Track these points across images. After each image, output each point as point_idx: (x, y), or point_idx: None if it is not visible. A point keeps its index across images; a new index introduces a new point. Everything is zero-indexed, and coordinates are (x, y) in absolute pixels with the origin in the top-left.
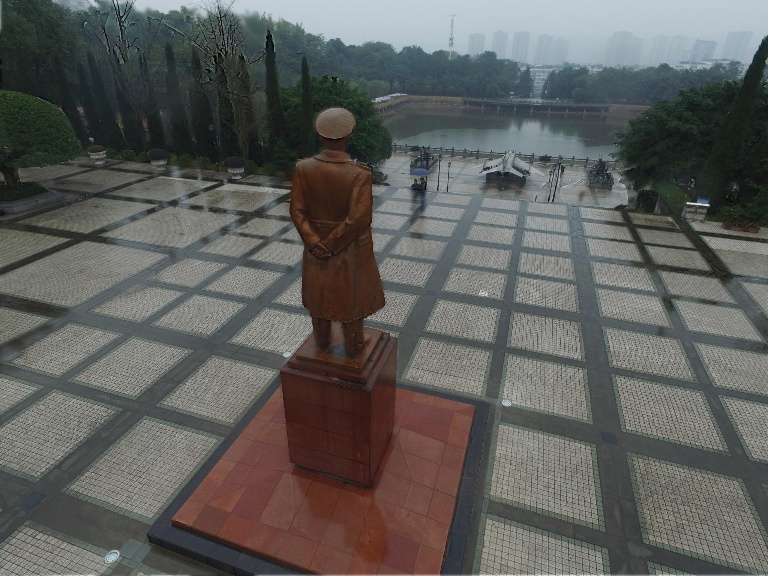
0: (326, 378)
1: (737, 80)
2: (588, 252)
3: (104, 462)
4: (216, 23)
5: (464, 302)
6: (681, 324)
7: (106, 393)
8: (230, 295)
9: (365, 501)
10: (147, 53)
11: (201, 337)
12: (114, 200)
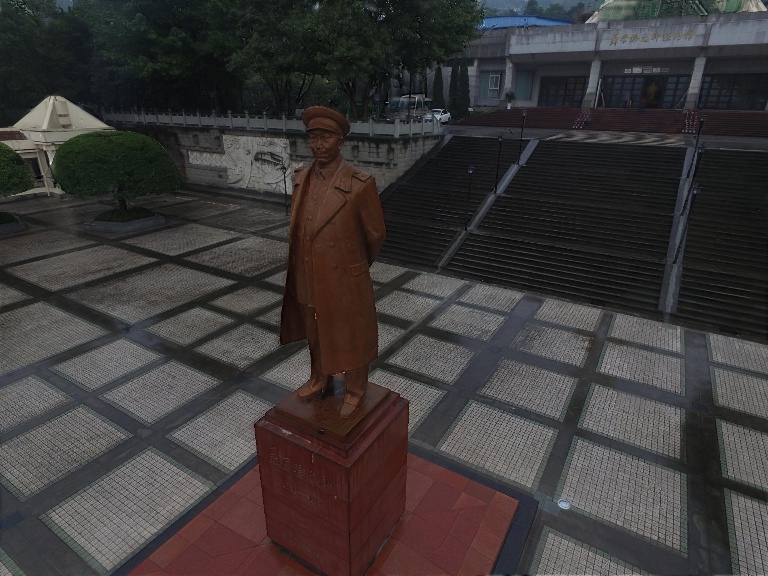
0: None
1: None
2: None
3: None
4: None
5: None
6: None
7: None
8: None
9: None
10: None
11: None
12: None
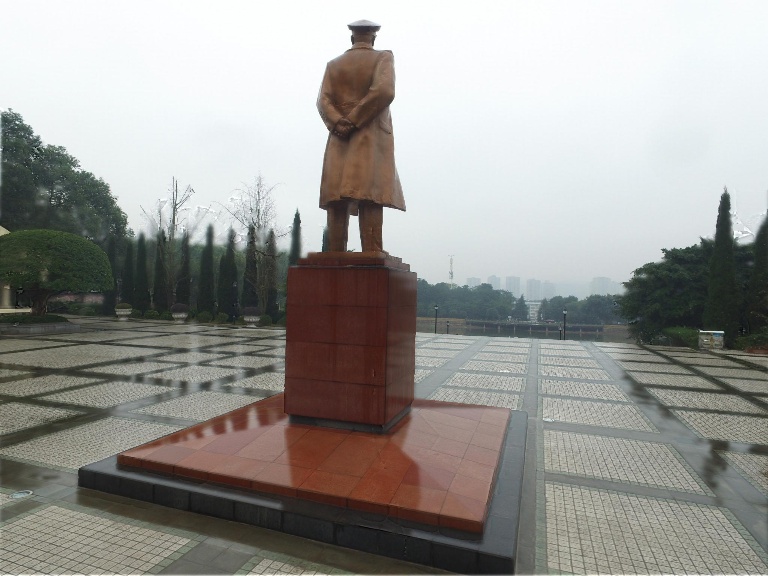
0: (339, 266)
1: (710, 238)
2: (610, 357)
3: (47, 438)
4: (255, 203)
5: (484, 374)
6: (733, 388)
7: (72, 404)
8: (231, 366)
9: (378, 441)
10: (191, 232)
11: (193, 382)
12: (129, 331)
